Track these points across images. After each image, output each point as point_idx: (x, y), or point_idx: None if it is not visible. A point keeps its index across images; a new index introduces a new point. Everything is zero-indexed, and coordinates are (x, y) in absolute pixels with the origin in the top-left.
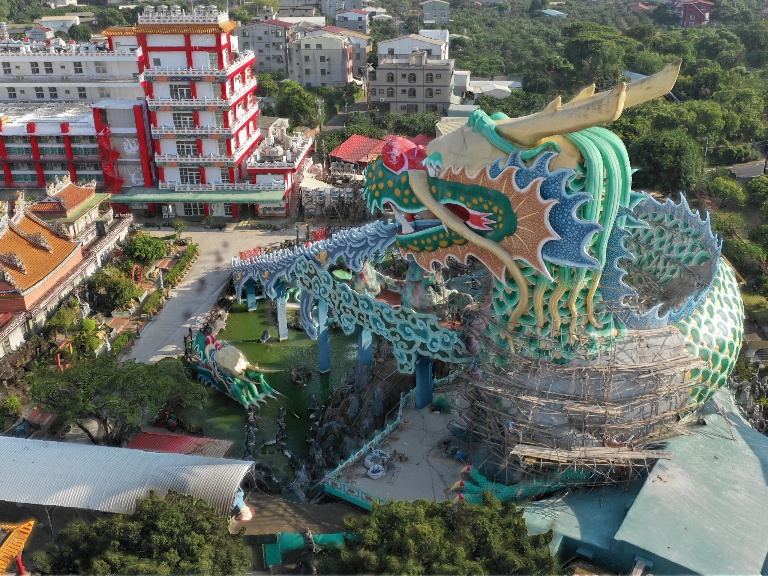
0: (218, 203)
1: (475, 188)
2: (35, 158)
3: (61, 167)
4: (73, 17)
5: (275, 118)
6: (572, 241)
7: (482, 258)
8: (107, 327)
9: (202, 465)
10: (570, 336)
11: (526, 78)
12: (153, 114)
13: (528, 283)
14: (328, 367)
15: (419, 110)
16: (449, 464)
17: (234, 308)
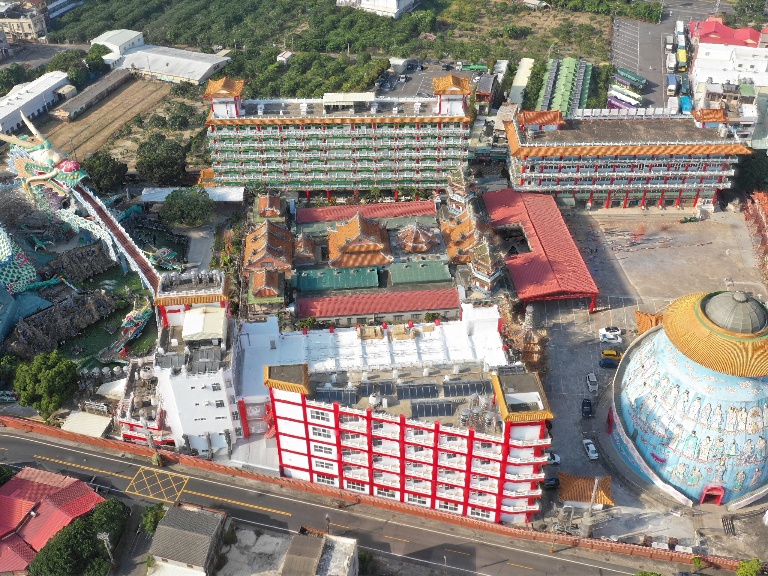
0: None
1: None
2: None
3: None
4: None
5: (163, 523)
6: None
7: None
8: None
9: (155, 192)
10: None
11: None
12: None
13: None
14: None
15: None
16: None
17: None
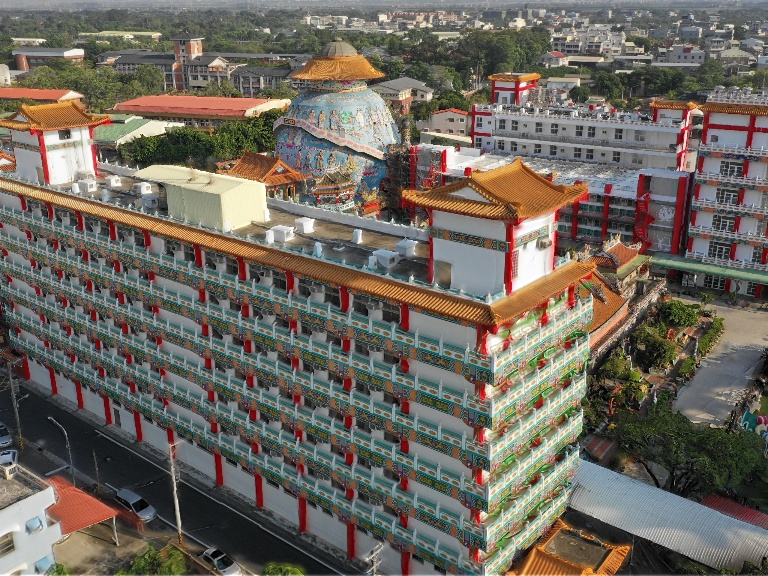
0: (742, 281)
1: None
2: (574, 212)
3: (595, 223)
4: (576, 80)
5: None
6: None
7: None
8: (647, 382)
9: None
10: None
11: None
12: (697, 187)
13: None
14: None
15: None
16: None
17: (767, 391)
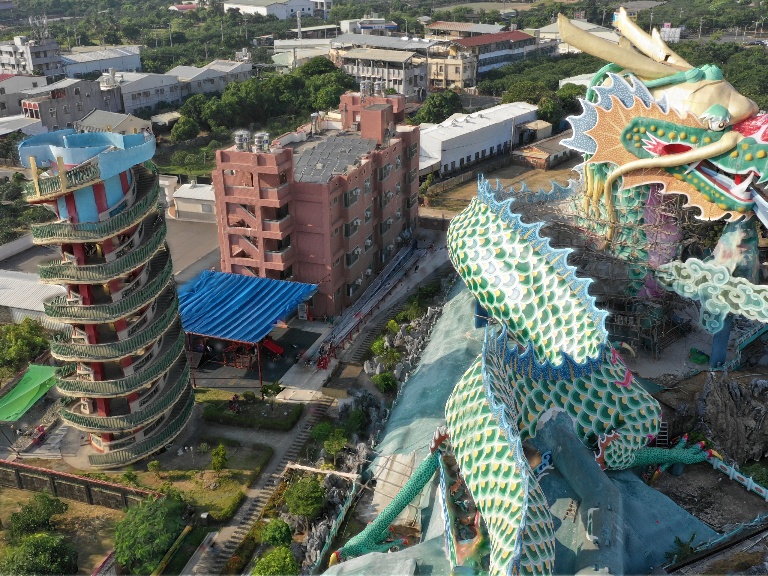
0: None
1: None
2: None
3: None
4: None
5: None
6: None
7: None
8: None
9: None
10: None
11: None
12: None
13: None
14: None
15: None
16: None
17: None
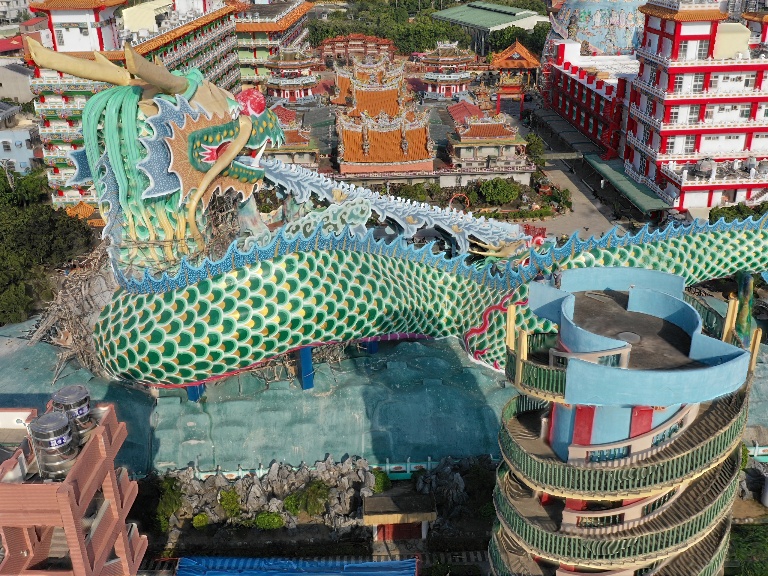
0: None
1: None
2: None
3: None
4: None
5: None
6: None
7: None
8: None
9: None
10: None
11: None
12: (638, 93)
13: None
14: None
15: None
16: None
17: None
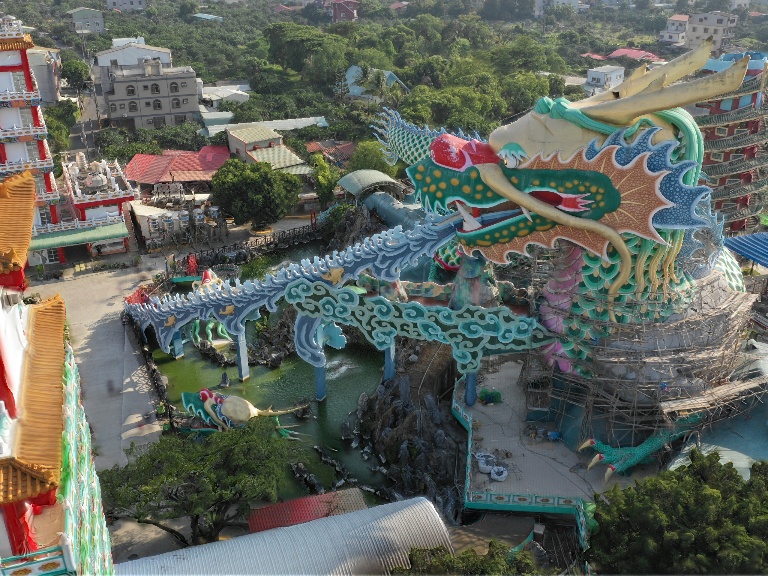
0: None
1: (570, 172)
2: None
3: None
4: None
5: None
6: (682, 206)
7: (576, 239)
8: None
9: (383, 517)
10: (664, 295)
11: (254, 81)
12: None
13: (631, 254)
14: (324, 393)
15: (167, 122)
16: (549, 447)
17: (157, 360)
